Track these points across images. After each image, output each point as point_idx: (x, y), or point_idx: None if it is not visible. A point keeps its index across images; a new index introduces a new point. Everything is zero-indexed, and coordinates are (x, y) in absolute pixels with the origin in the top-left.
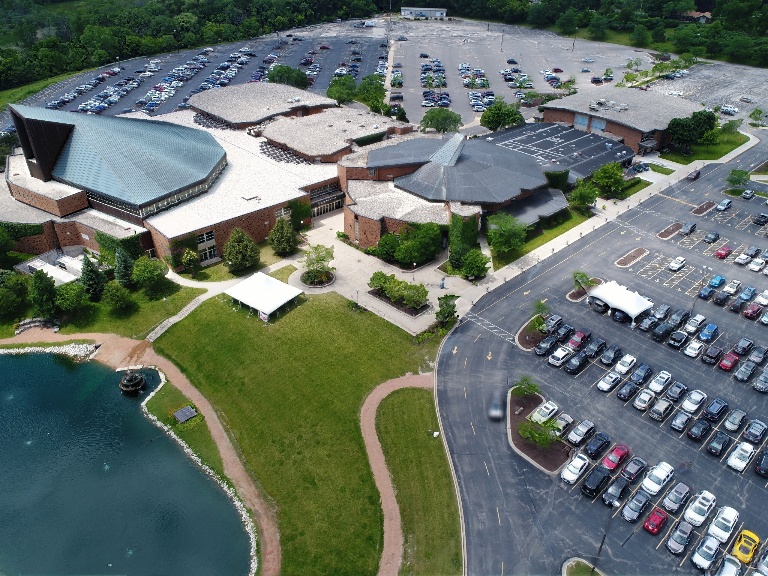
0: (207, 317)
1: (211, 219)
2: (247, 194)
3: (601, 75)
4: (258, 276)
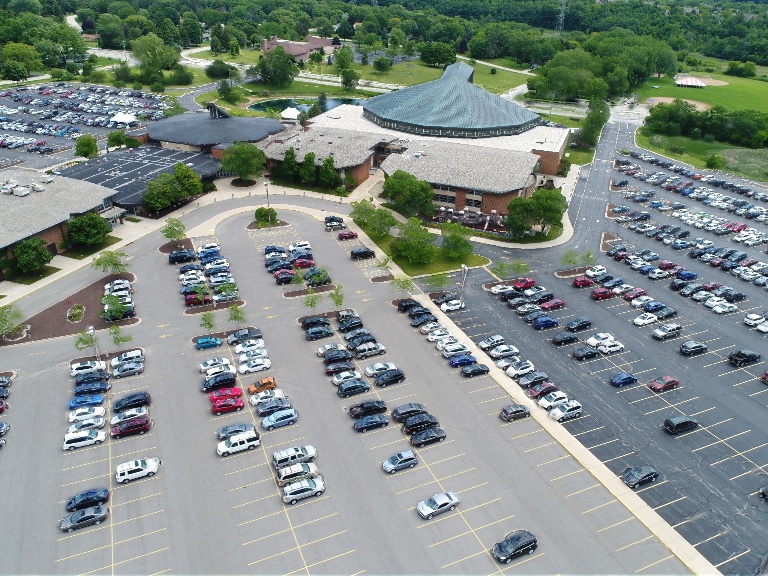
0: None
1: None
2: None
3: None
4: None
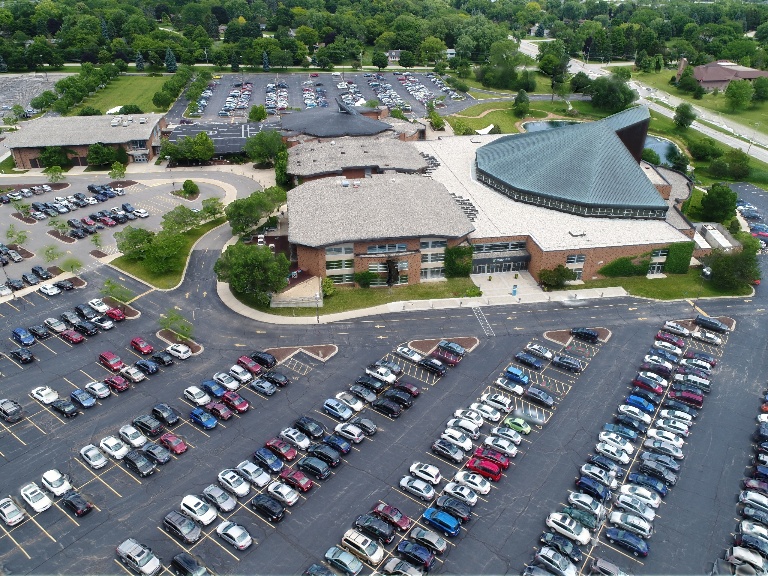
0: None
1: None
2: (476, 143)
3: None
4: None
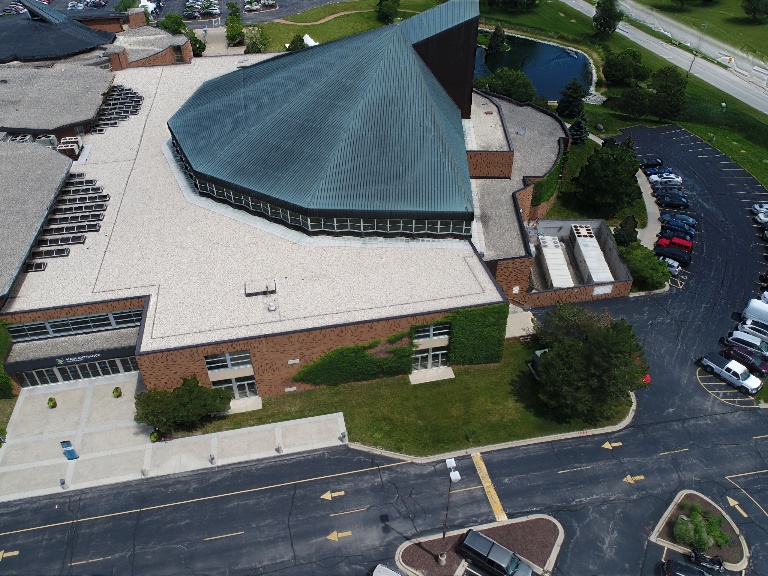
0: None
1: None
2: None
3: None
4: None
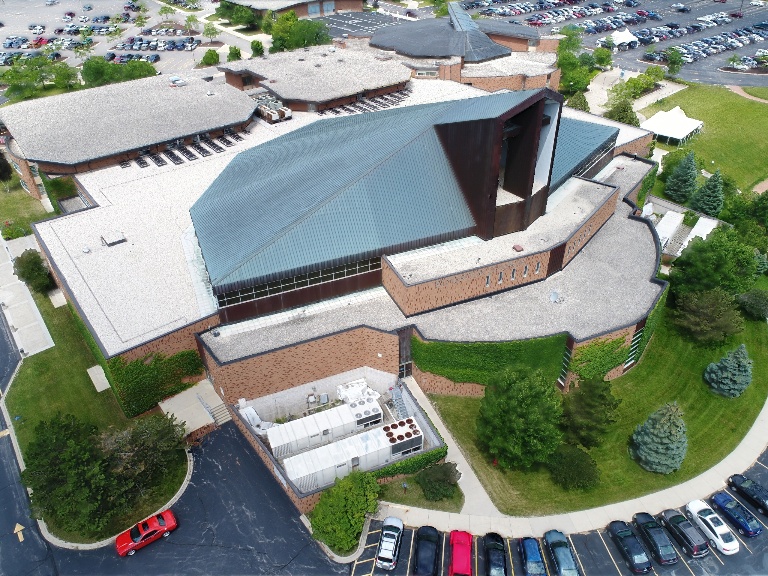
0: (705, 157)
1: (590, 120)
2: None
3: (112, 7)
4: (673, 110)
